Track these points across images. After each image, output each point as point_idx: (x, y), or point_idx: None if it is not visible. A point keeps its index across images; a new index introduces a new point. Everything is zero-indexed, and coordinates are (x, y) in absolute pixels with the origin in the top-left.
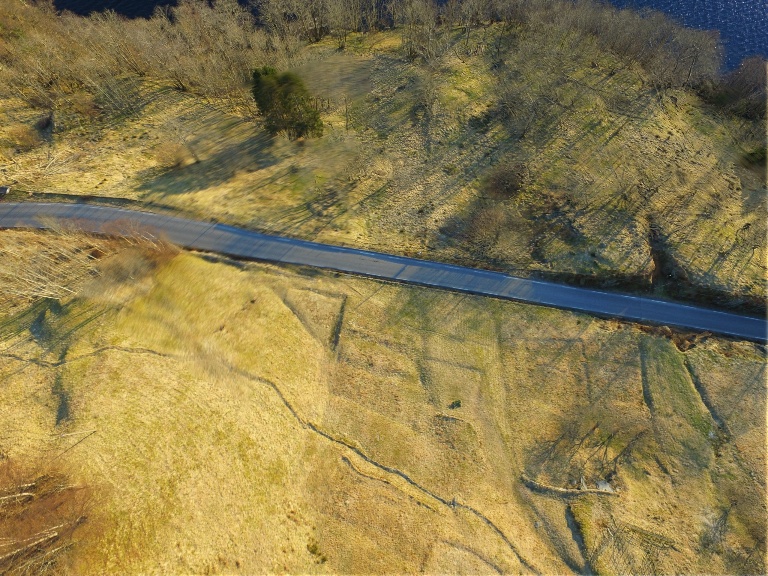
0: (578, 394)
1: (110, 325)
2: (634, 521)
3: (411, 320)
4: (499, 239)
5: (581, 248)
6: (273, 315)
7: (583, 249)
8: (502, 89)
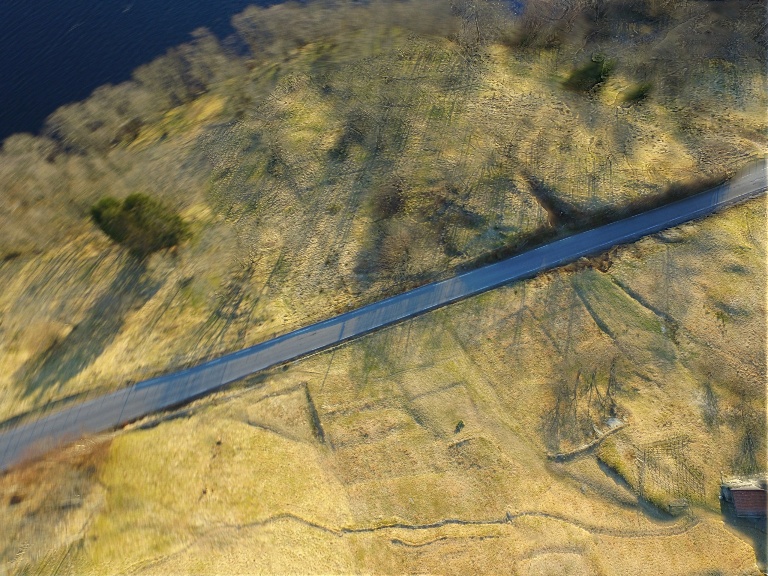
0: (550, 355)
1: (82, 562)
2: (651, 438)
3: (377, 371)
4: (410, 253)
5: (482, 227)
6: (247, 443)
7: (485, 227)
8: (335, 113)
